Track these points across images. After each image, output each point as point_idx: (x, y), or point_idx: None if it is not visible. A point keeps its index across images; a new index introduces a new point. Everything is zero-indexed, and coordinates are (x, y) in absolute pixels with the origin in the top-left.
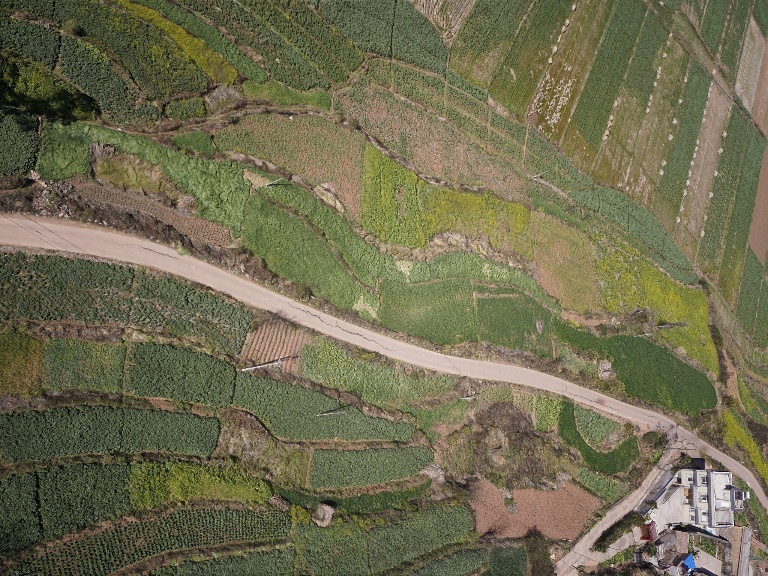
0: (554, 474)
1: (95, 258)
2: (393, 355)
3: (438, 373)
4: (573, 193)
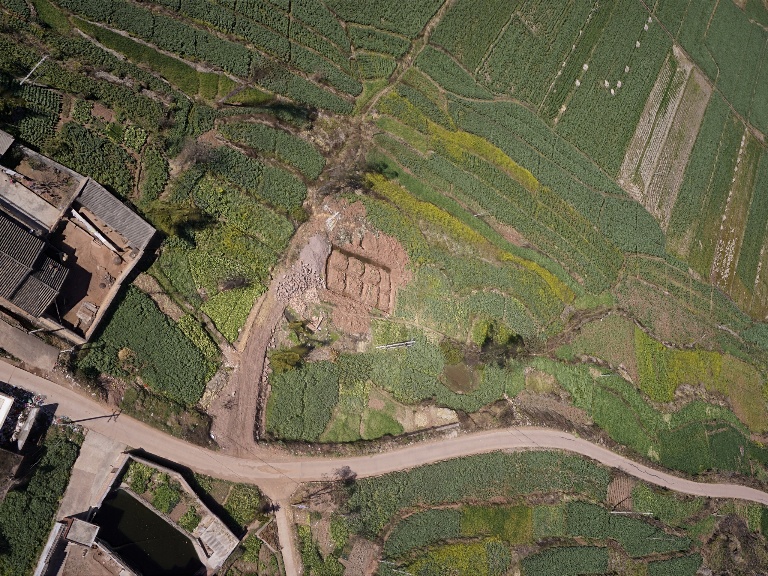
0: (767, 566)
1: (543, 449)
2: (672, 487)
3: (695, 496)
4: (742, 333)
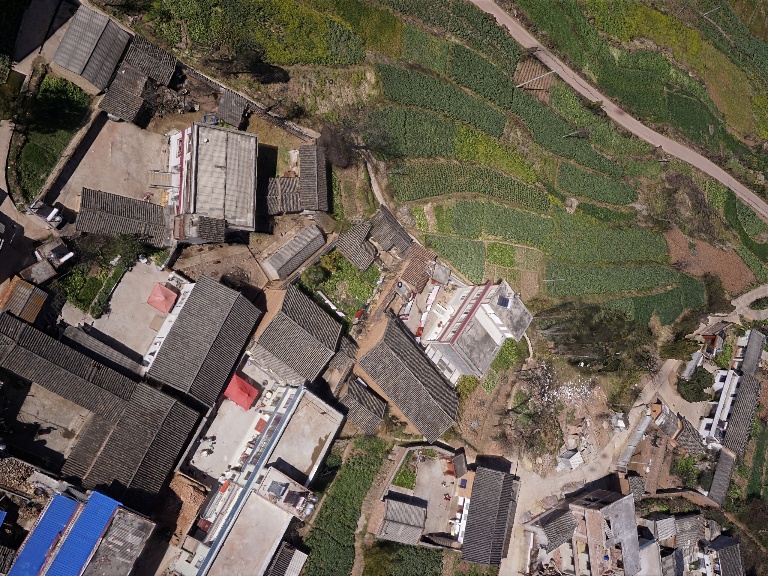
0: (723, 240)
1: None
2: (609, 114)
3: (639, 139)
4: (734, 37)
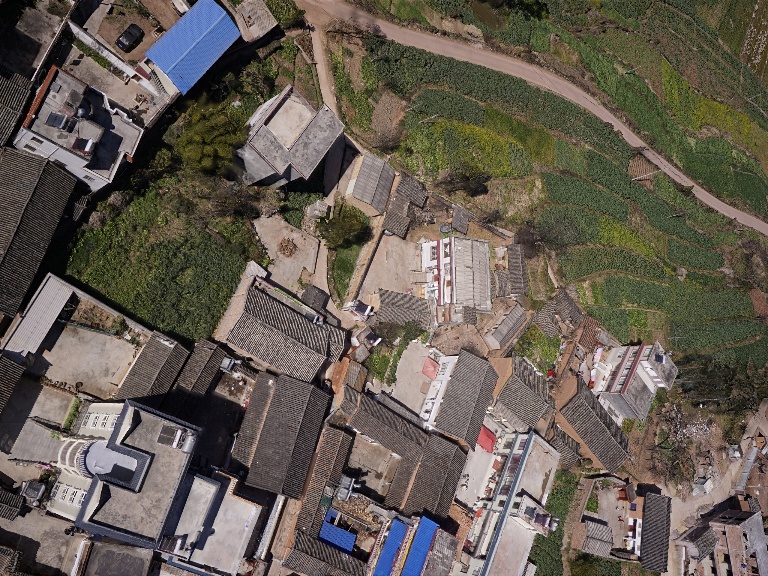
0: None
1: (566, 98)
2: (695, 194)
3: (718, 213)
4: None
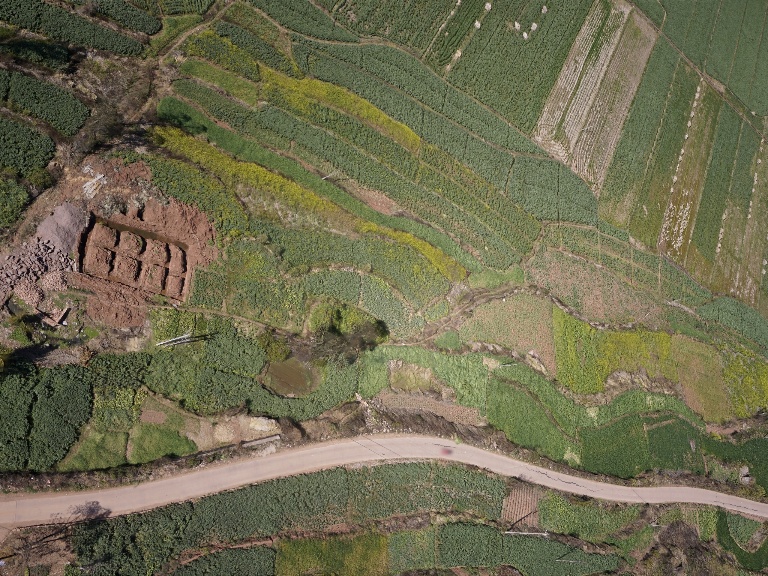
0: None
1: (407, 460)
2: (597, 495)
3: (628, 504)
4: (699, 309)
